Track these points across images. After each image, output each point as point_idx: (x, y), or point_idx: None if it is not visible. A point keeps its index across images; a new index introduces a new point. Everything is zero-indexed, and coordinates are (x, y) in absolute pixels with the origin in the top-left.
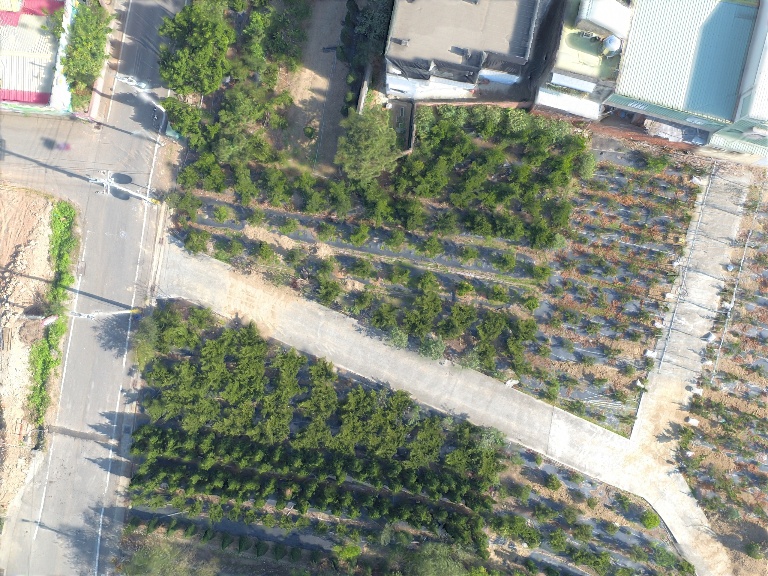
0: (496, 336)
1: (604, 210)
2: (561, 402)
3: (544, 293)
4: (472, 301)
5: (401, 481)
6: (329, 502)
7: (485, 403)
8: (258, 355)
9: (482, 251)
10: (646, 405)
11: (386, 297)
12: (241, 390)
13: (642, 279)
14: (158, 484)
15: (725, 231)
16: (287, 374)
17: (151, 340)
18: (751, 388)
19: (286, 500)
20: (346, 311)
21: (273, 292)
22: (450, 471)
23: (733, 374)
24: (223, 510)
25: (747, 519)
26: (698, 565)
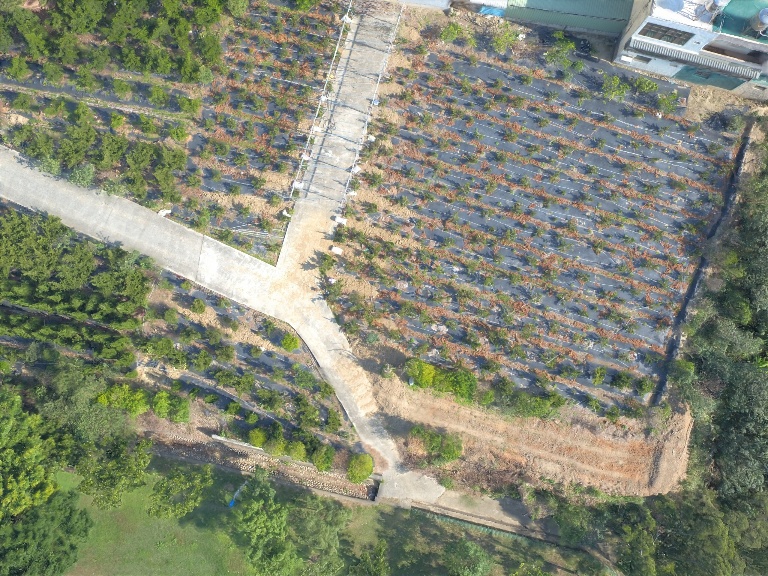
0: (143, 164)
1: (258, 47)
2: (211, 231)
3: (198, 127)
4: (129, 134)
5: (46, 300)
6: None
7: (138, 232)
8: None
9: (140, 87)
10: (292, 234)
11: (48, 131)
12: None
13: (292, 113)
14: None
15: (374, 67)
16: None
17: None
18: (395, 219)
19: None
20: (8, 144)
21: None
22: (99, 294)
23: (377, 205)
24: None
25: (387, 344)
26: (339, 388)
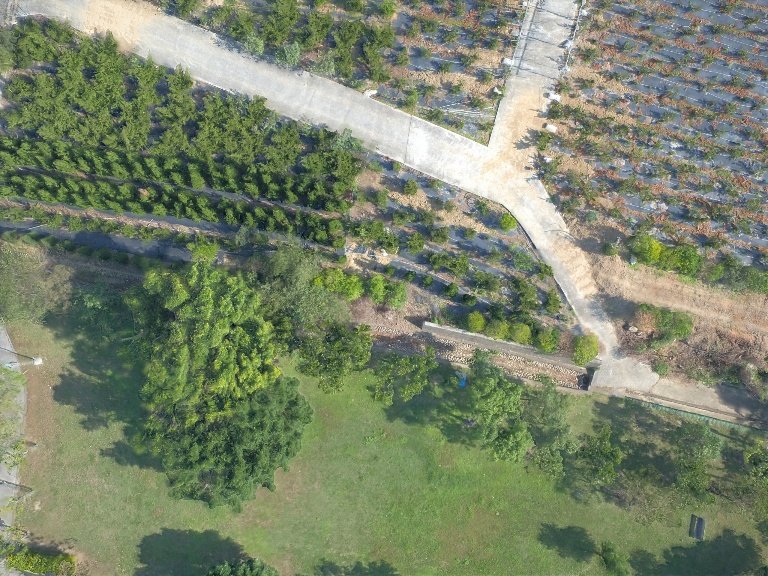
0: (351, 41)
1: None
2: (419, 111)
3: (402, 5)
4: (330, 14)
5: (255, 182)
6: (183, 204)
7: (343, 113)
8: (115, 65)
9: None
10: (504, 112)
11: (245, 12)
12: (97, 99)
13: None
14: (14, 191)
15: None
16: (143, 83)
17: (6, 47)
18: (609, 95)
19: (141, 203)
20: (204, 25)
21: (131, 7)
22: (307, 176)
23: None
24: (82, 221)
25: (605, 224)
26: (557, 269)
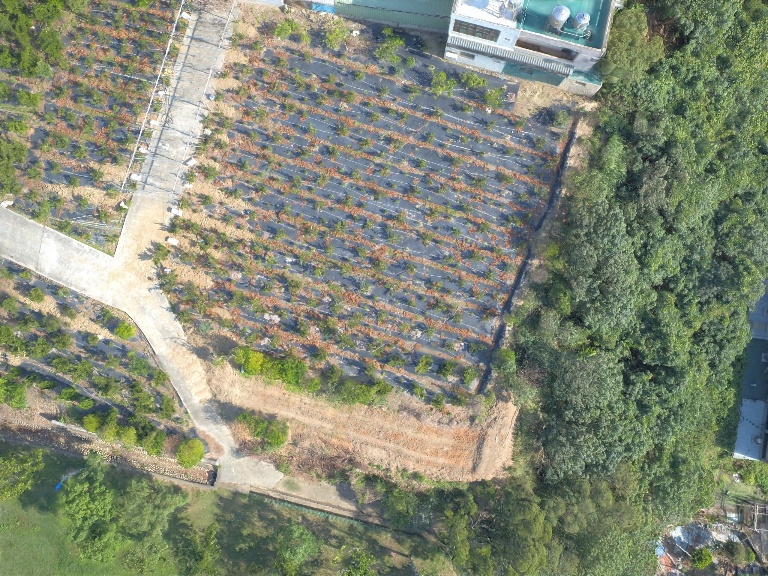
0: None
1: (99, 43)
2: (51, 222)
3: (40, 120)
4: None
5: None
6: None
7: None
8: None
9: None
10: (130, 225)
11: None
12: None
13: (131, 107)
14: None
15: (211, 63)
16: None
17: None
18: (230, 210)
19: None
20: None
21: None
22: None
23: (213, 197)
24: None
25: (221, 333)
26: (174, 375)
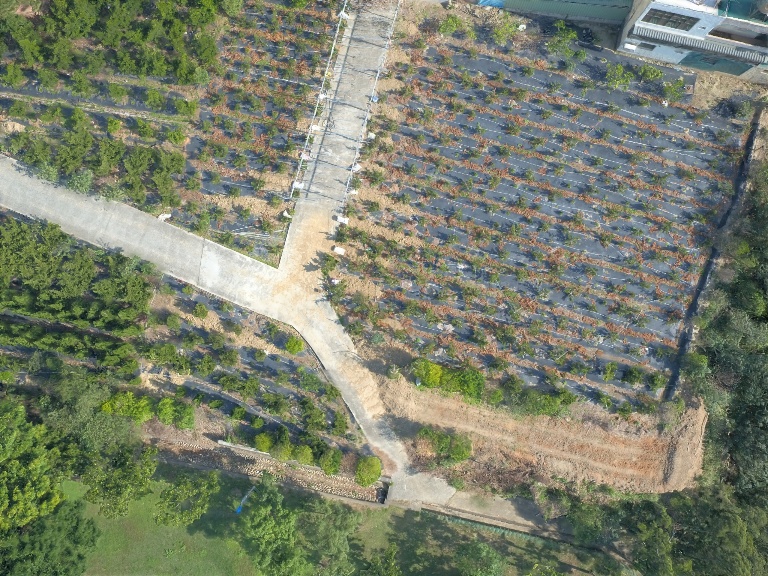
0: (141, 169)
1: (254, 47)
2: (212, 234)
3: (196, 129)
4: (126, 139)
5: (48, 309)
6: None
7: (138, 237)
8: None
9: (136, 90)
10: (293, 235)
11: (45, 138)
12: None
13: (290, 113)
14: None
15: (372, 63)
16: None
17: None
18: (397, 217)
19: None
20: (6, 152)
21: None
22: (100, 301)
23: (379, 203)
24: None
25: (393, 344)
26: (345, 390)
